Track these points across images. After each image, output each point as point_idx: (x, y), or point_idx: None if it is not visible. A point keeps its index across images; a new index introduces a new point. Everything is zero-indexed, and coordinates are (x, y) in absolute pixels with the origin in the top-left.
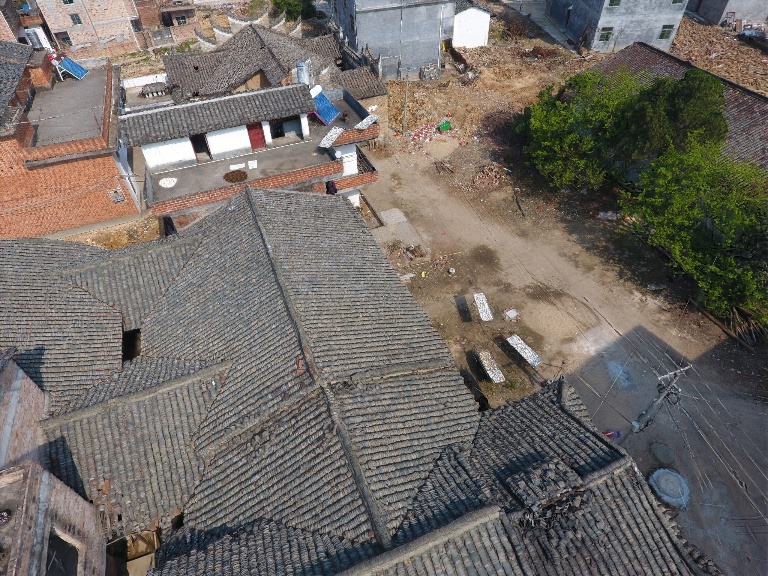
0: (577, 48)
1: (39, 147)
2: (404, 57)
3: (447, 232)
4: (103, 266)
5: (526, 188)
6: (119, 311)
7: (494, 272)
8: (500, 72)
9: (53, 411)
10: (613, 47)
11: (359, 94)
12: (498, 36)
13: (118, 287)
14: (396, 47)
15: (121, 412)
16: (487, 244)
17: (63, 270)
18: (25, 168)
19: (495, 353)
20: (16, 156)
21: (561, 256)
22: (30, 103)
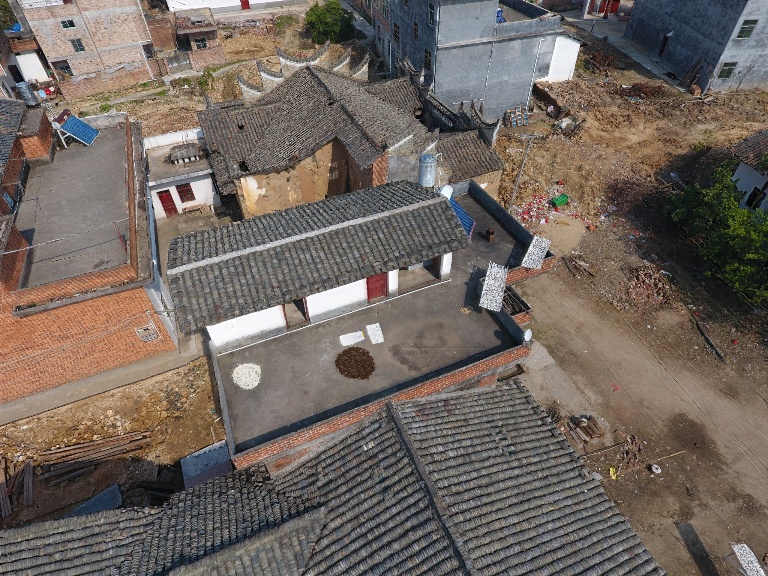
0: (685, 85)
1: (36, 287)
2: (488, 100)
3: (620, 386)
4: None
5: (703, 305)
6: None
7: (717, 470)
8: (604, 118)
9: None
10: (735, 86)
11: (468, 171)
12: (581, 66)
13: None
14: (480, 89)
15: None
16: (686, 411)
17: None
18: None
19: None
20: (1, 302)
21: None
22: None
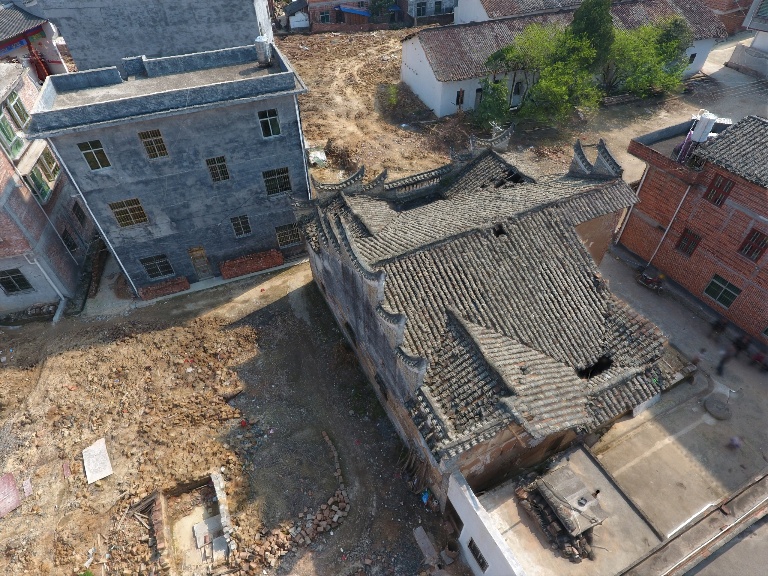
0: None
1: None
2: None
3: None
4: None
5: (557, 142)
6: None
7: None
8: (313, 136)
9: None
10: None
11: None
12: None
13: None
14: None
15: None
16: None
17: None
18: None
19: None
20: None
21: None
22: None
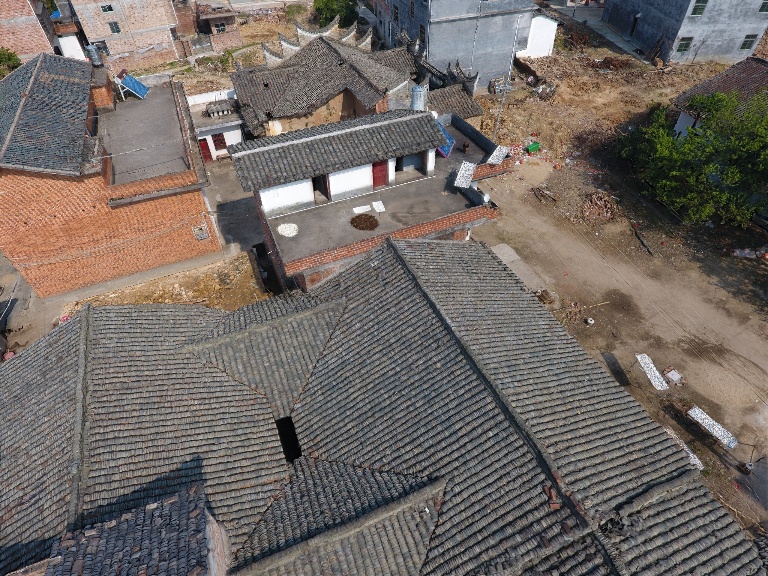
0: (650, 59)
1: (125, 184)
2: (474, 70)
3: (569, 273)
4: (239, 339)
5: (642, 220)
6: (264, 396)
7: (637, 322)
8: (576, 85)
9: (235, 552)
10: (692, 58)
11: None
12: (560, 45)
13: (259, 365)
14: (467, 59)
15: (324, 555)
16: (619, 287)
17: (195, 346)
18: (108, 207)
19: (670, 426)
20: (100, 194)
21: (707, 303)
22: (95, 127)
